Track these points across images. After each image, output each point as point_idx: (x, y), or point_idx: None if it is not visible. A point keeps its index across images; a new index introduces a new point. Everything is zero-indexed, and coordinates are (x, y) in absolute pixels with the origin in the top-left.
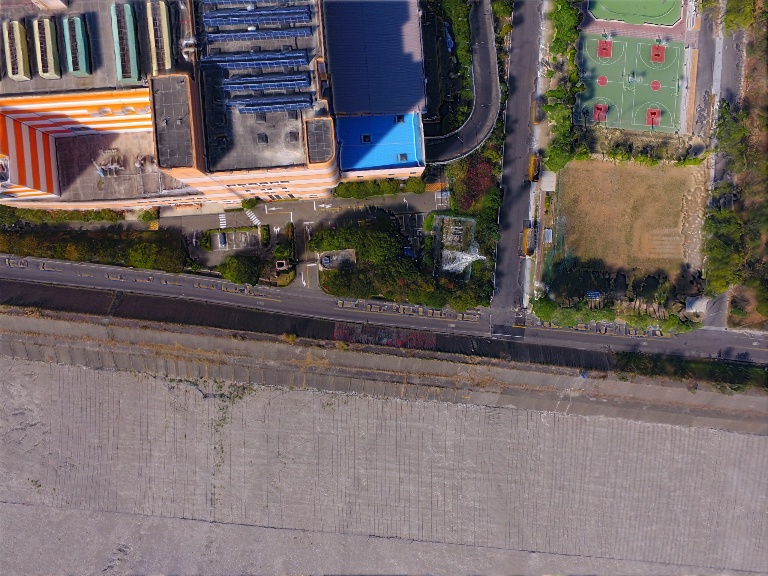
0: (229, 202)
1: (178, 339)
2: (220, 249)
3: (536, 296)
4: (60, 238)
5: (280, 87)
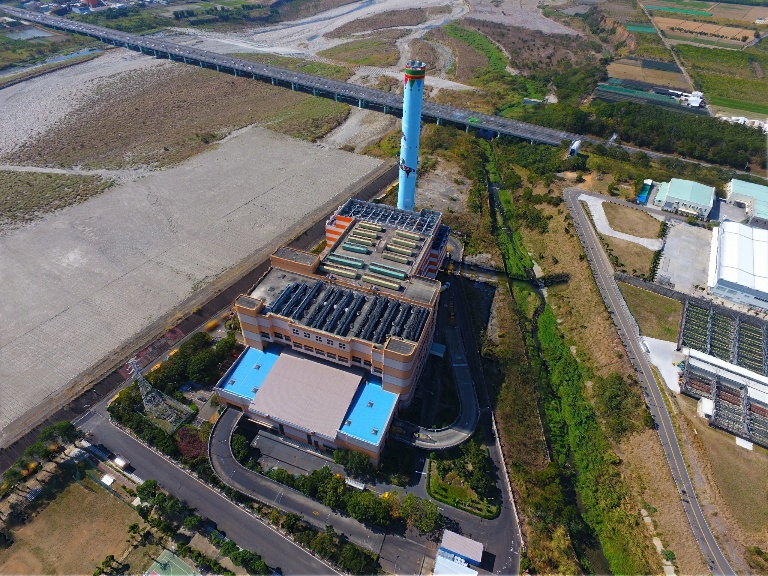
0: None
1: None
2: None
3: (80, 451)
4: None
5: None
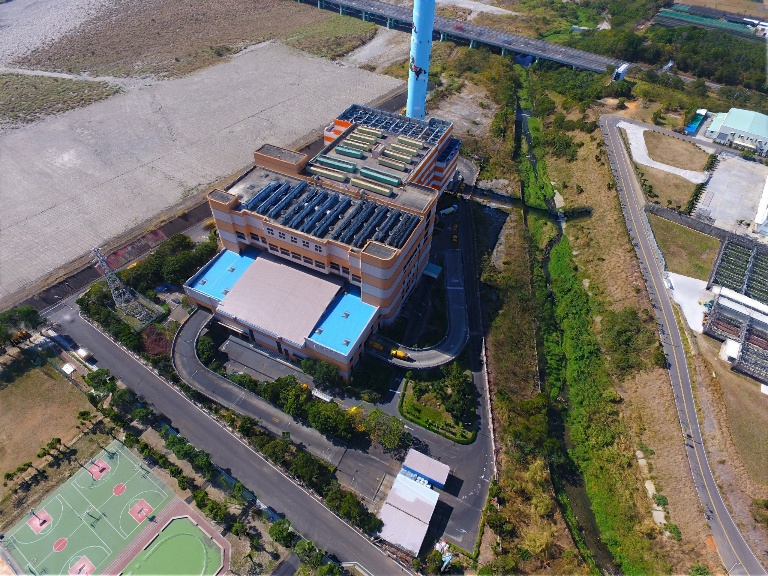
0: None
1: None
2: None
3: (46, 339)
4: None
5: None
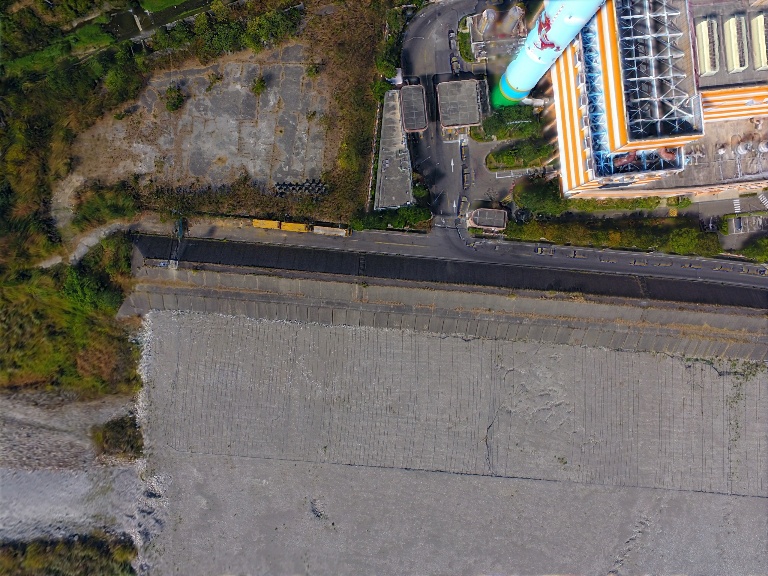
0: (756, 187)
1: (709, 319)
2: (735, 233)
3: None
4: (588, 226)
5: None
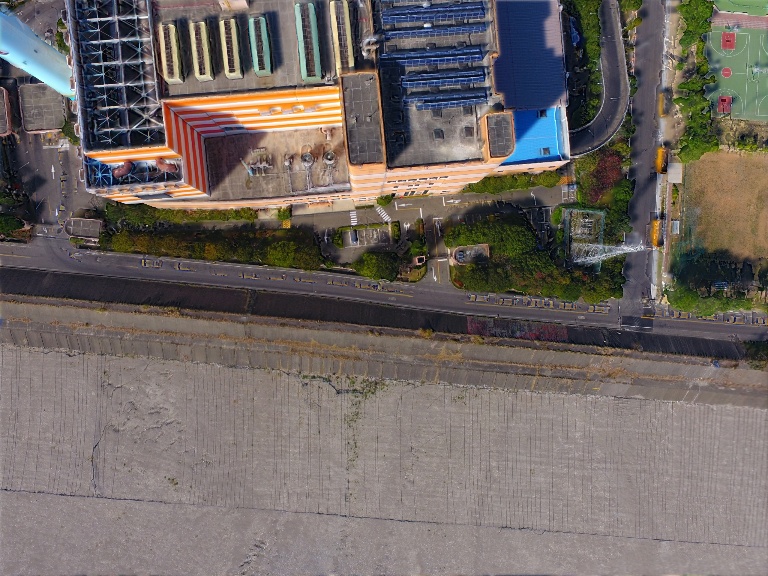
0: (363, 199)
1: (315, 336)
2: (351, 246)
3: (664, 287)
4: (195, 238)
5: (456, 83)
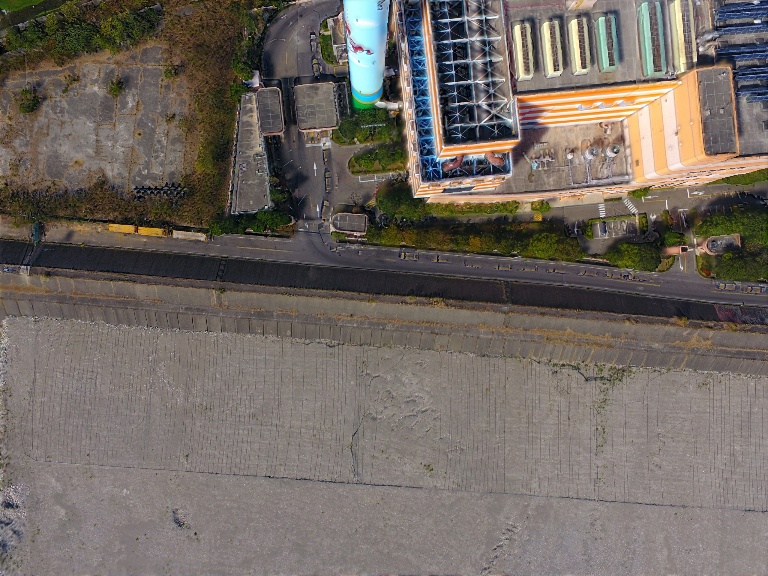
0: None
1: (571, 324)
2: (600, 237)
3: None
4: (452, 231)
5: None
